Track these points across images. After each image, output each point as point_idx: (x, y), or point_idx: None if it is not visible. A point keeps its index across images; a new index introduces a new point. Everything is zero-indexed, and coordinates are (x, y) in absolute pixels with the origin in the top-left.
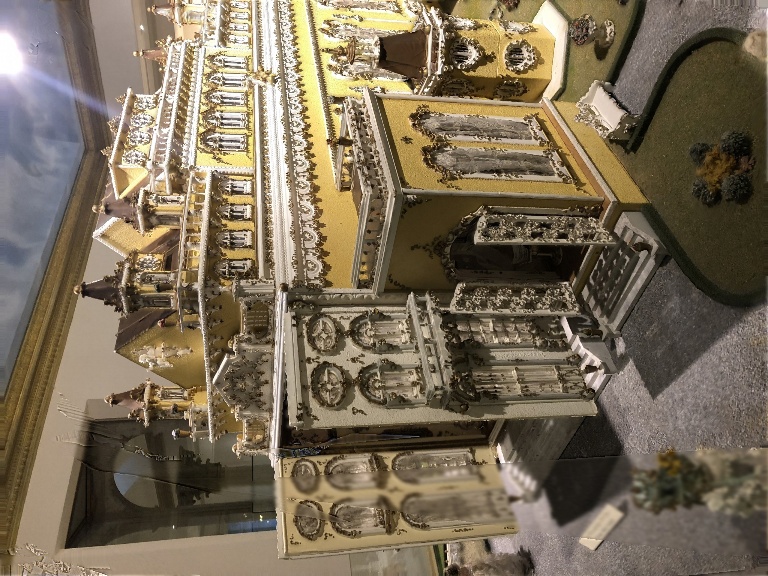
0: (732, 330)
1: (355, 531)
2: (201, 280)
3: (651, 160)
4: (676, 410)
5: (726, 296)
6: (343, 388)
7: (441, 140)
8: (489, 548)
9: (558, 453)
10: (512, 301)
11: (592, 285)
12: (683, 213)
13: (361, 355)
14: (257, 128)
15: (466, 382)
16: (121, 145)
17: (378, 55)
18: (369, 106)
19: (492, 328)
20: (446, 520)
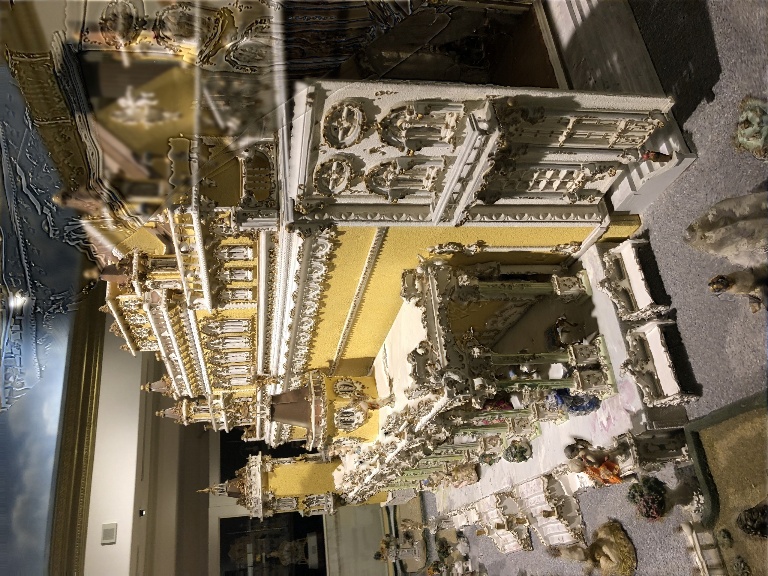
0: None
1: None
2: None
3: None
4: None
5: None
6: None
7: None
8: (760, 393)
9: (649, 68)
10: None
11: None
12: None
13: None
14: None
15: None
16: None
17: None
18: None
19: None
20: None
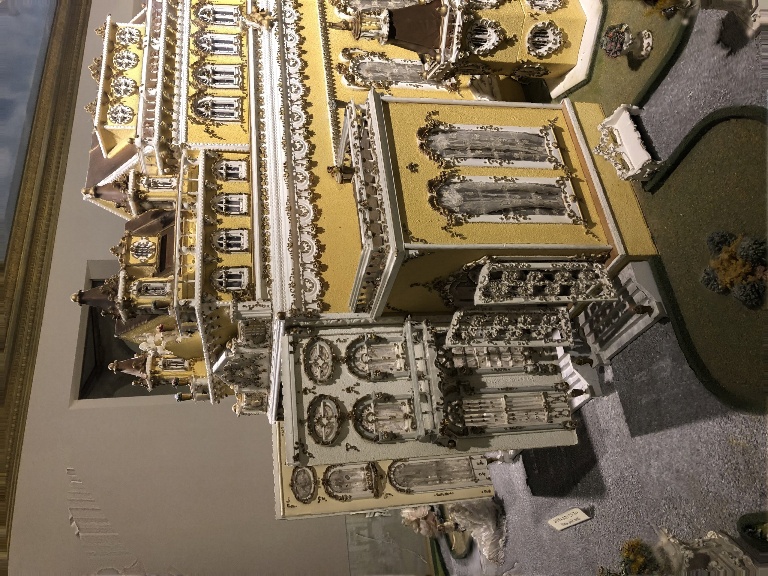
0: (715, 419)
1: (346, 496)
2: (198, 299)
3: (667, 211)
4: (651, 458)
5: (716, 388)
6: (338, 424)
7: (449, 166)
8: None
9: None
10: (508, 330)
11: (589, 315)
12: (690, 283)
13: (356, 384)
14: (252, 94)
15: (456, 413)
16: (105, 97)
17: (387, 34)
18: (374, 118)
19: (486, 349)
20: (429, 485)
